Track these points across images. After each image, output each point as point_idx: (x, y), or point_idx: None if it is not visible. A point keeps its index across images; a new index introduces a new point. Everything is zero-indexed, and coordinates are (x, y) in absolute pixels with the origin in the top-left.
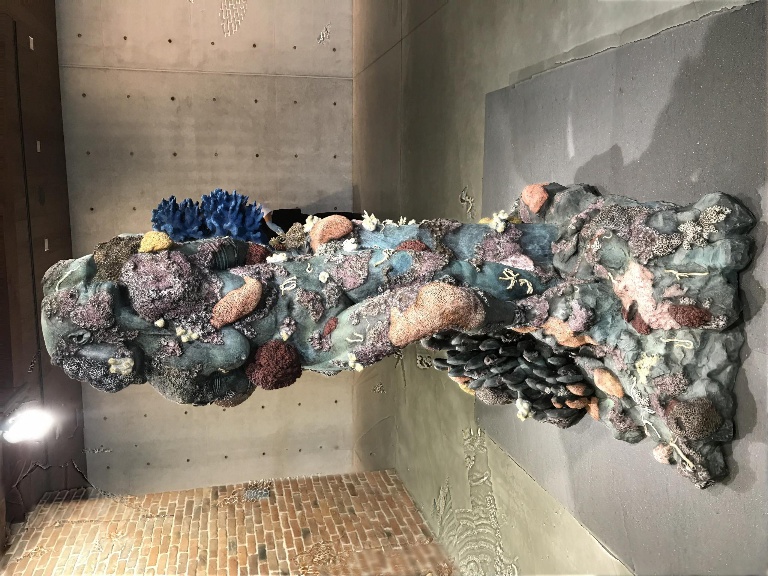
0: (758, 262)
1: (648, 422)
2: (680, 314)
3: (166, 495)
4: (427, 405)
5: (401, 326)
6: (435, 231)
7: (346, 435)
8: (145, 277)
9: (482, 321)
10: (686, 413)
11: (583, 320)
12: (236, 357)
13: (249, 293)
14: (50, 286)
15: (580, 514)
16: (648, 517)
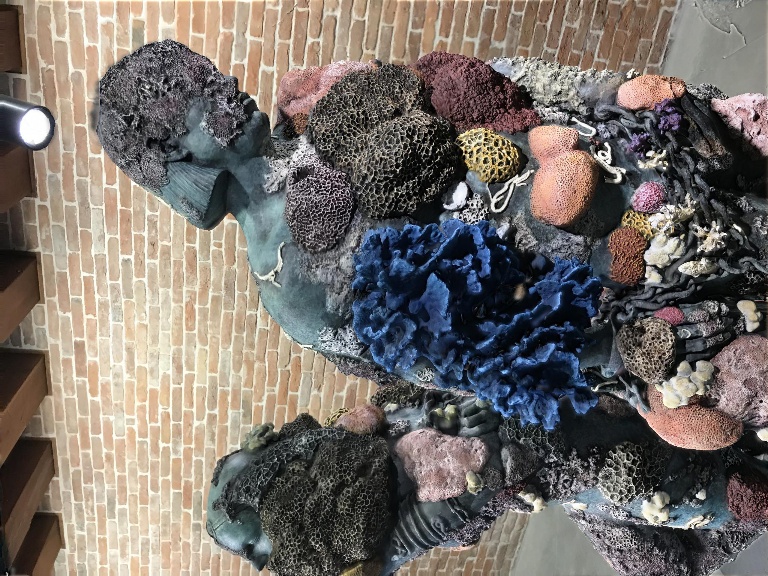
0: None
1: None
2: None
3: None
4: None
5: None
6: None
7: None
8: None
9: None
10: None
11: None
12: None
13: None
14: None
15: None
16: None
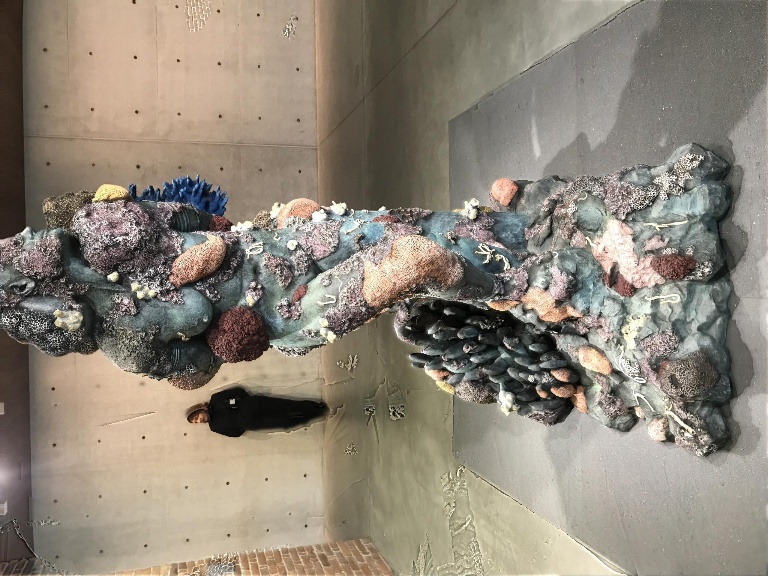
0: (736, 207)
1: (640, 395)
2: (664, 265)
3: (119, 575)
4: (402, 458)
5: (376, 280)
6: (406, 217)
7: (317, 500)
8: (98, 223)
9: (461, 278)
10: (680, 369)
11: (564, 285)
12: (197, 319)
13: (212, 249)
14: None
15: (573, 528)
16: (647, 510)
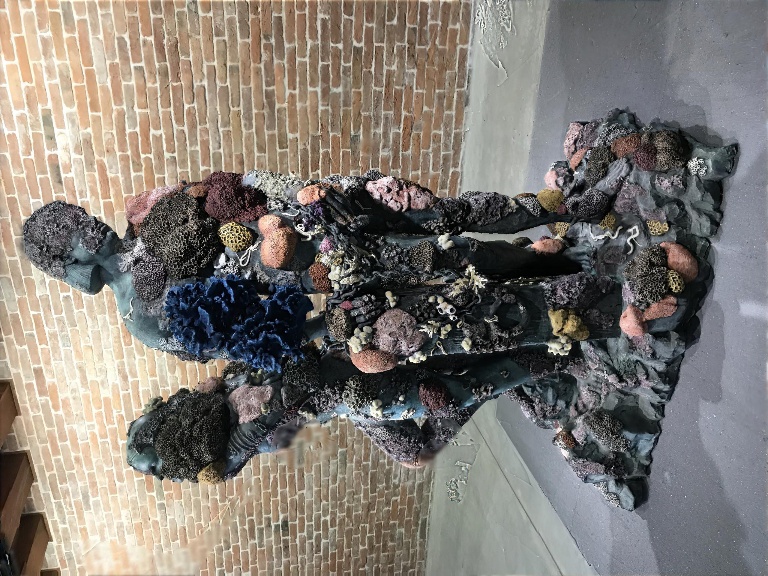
0: None
1: None
2: None
3: None
4: None
5: None
6: None
7: None
8: None
9: None
10: (537, 423)
11: None
12: None
13: None
14: None
15: None
16: None
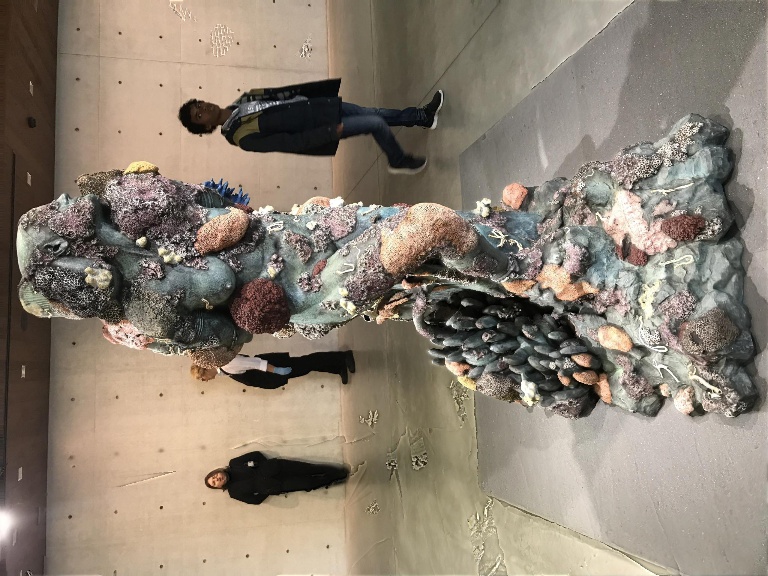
0: (739, 167)
1: (662, 366)
2: (674, 227)
3: None
4: (427, 508)
5: (393, 244)
6: None
7: (339, 561)
8: (129, 189)
9: (475, 244)
10: (699, 325)
11: (578, 257)
12: (221, 284)
13: (235, 218)
14: (26, 285)
15: (608, 534)
16: (682, 495)
